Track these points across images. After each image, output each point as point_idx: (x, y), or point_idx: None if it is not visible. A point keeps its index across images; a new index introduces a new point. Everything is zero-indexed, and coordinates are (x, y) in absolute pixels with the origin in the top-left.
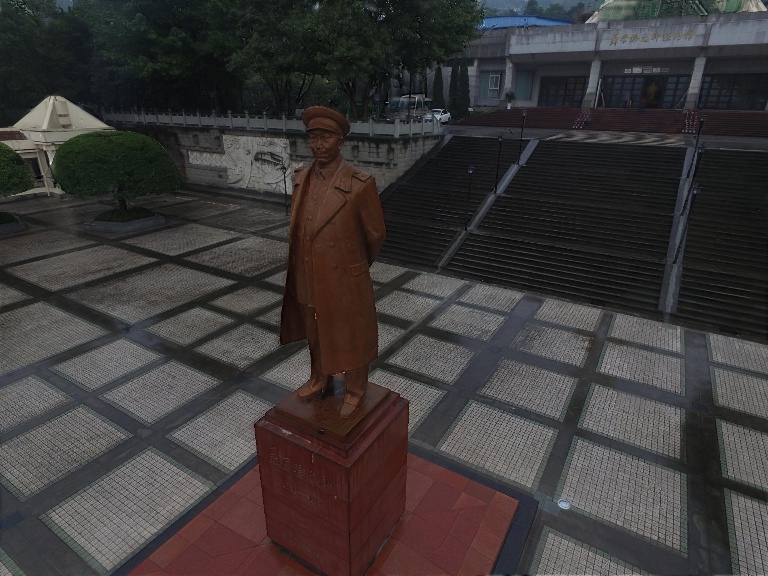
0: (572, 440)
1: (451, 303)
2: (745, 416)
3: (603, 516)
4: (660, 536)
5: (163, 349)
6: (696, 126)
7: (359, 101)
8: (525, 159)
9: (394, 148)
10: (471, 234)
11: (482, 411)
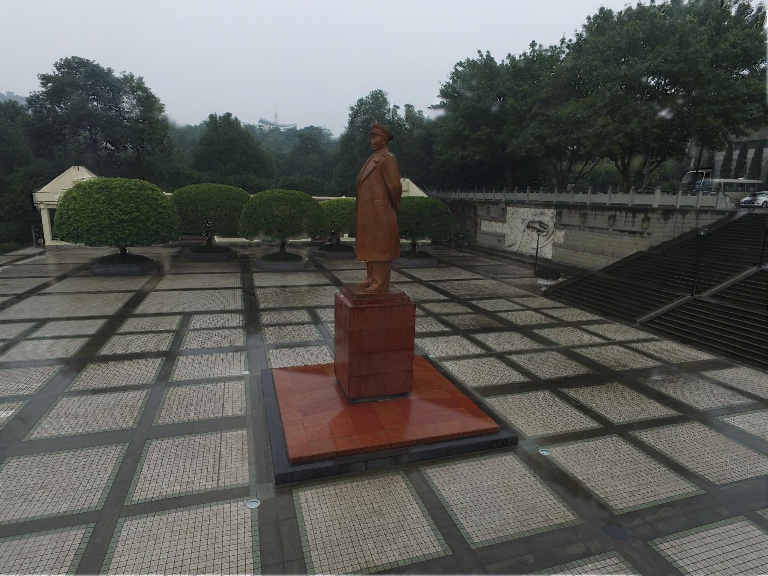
0: (608, 434)
1: (616, 344)
2: None
3: (570, 469)
4: (608, 497)
5: None
6: None
7: (632, 176)
8: None
9: (650, 217)
10: (696, 300)
11: (547, 397)
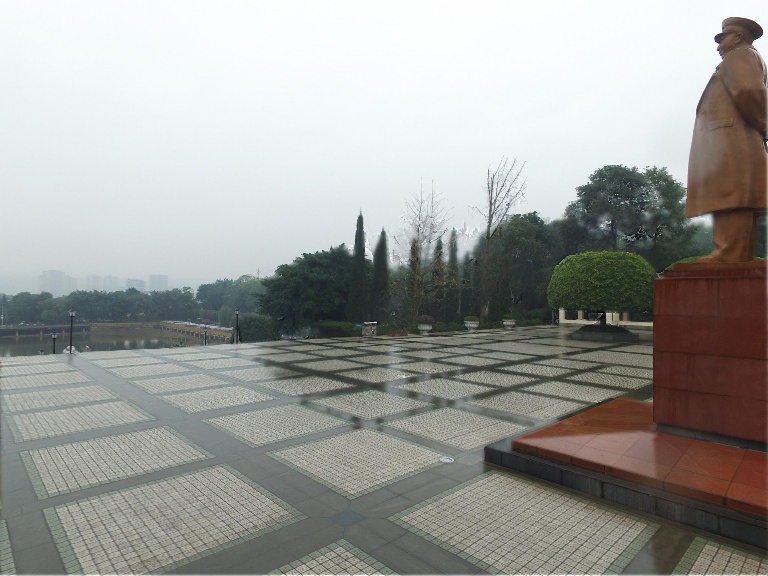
0: None
1: None
2: None
3: None
4: None
5: None
6: None
7: None
8: None
9: None
10: None
11: None
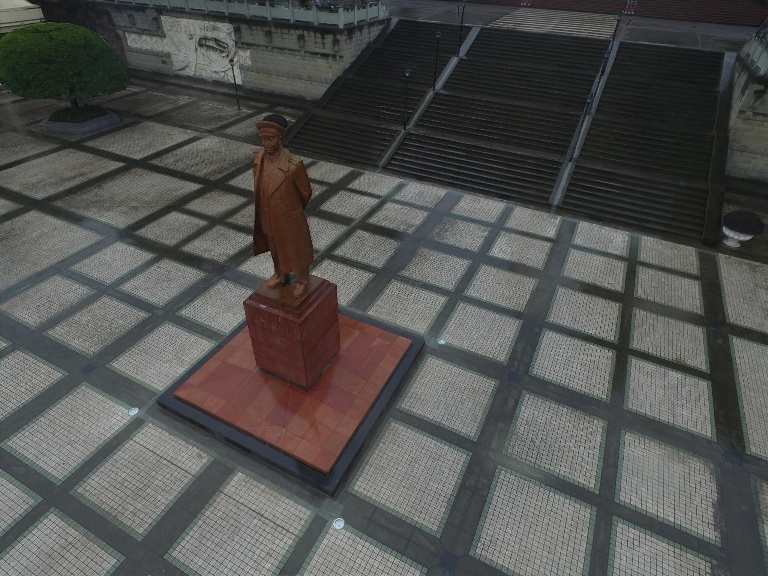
0: (457, 303)
1: (387, 201)
2: (577, 283)
3: (464, 347)
4: (494, 356)
5: (155, 249)
6: (636, 7)
7: None
8: (465, 50)
9: (339, 39)
10: (409, 133)
11: (399, 287)
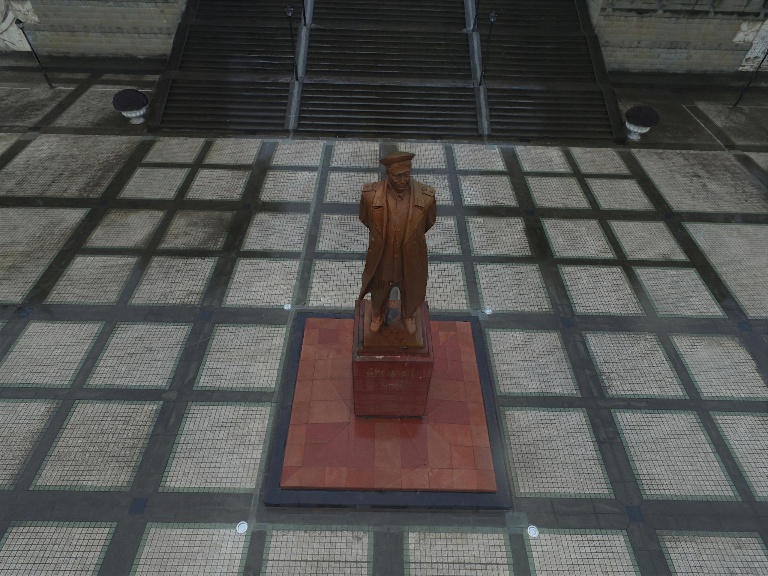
0: (473, 266)
1: (327, 171)
2: (553, 210)
3: (510, 309)
4: (539, 308)
5: (94, 316)
6: None
7: None
8: None
9: None
10: (304, 84)
11: None
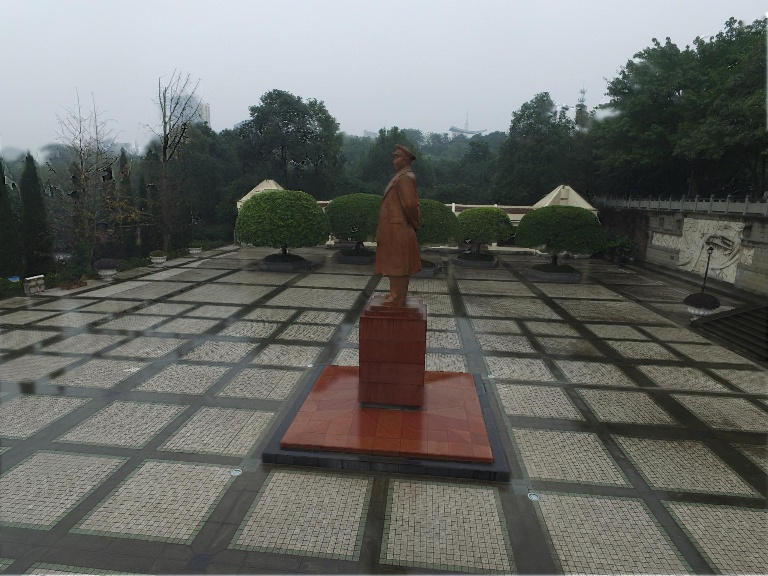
0: (631, 497)
1: (742, 397)
2: None
3: (548, 521)
4: (568, 561)
5: (463, 328)
6: None
7: None
8: None
9: None
10: None
11: (588, 440)
